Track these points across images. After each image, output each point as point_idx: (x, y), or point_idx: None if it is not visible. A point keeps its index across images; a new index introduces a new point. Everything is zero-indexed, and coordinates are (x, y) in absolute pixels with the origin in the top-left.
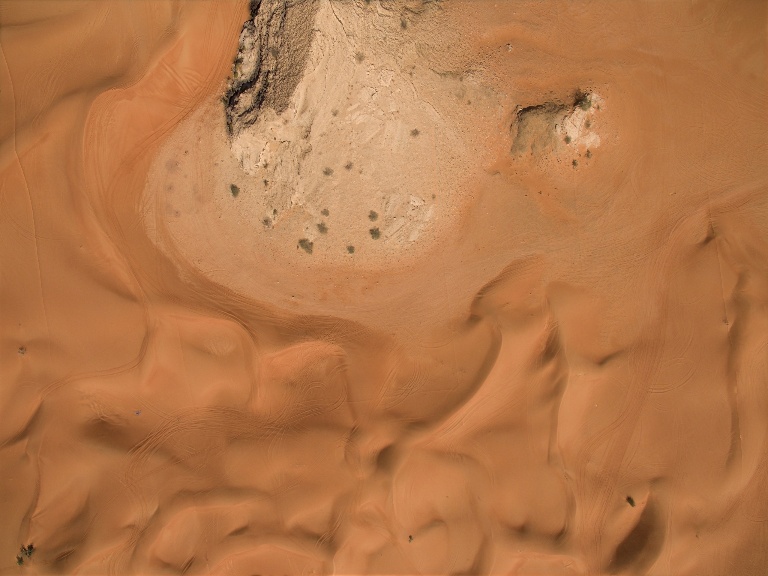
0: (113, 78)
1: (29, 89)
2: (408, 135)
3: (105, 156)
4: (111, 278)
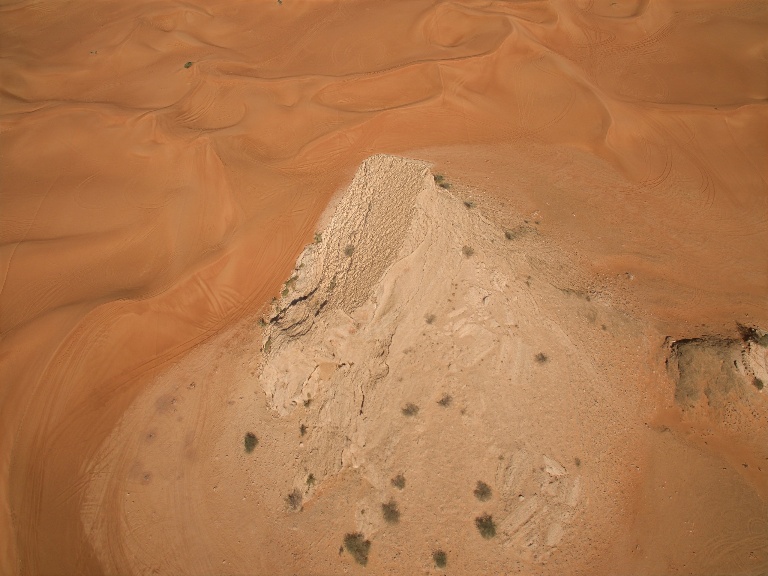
0: (128, 290)
1: (17, 302)
2: (531, 360)
3: (72, 382)
4: None
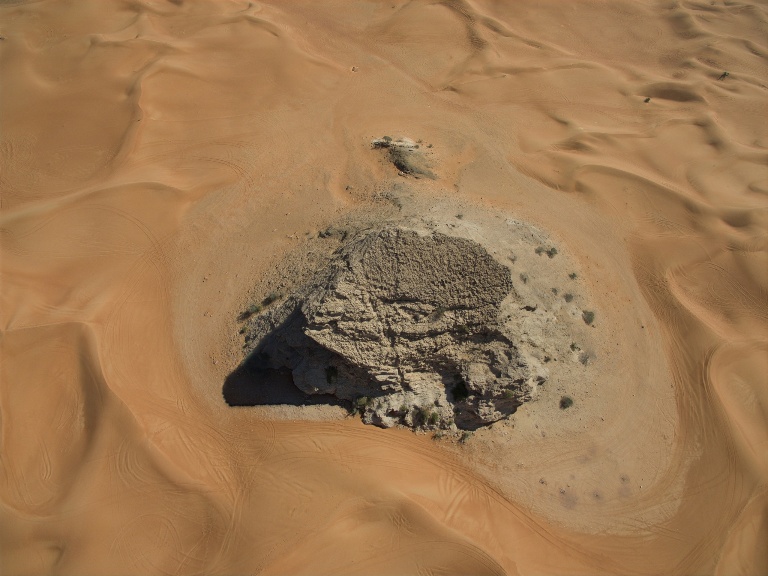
0: None
1: None
2: None
3: None
4: (763, 563)
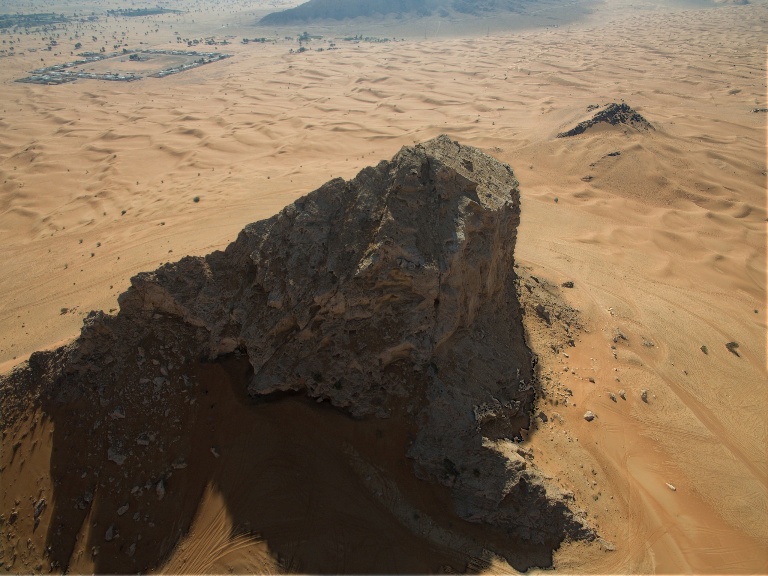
0: None
1: None
2: None
3: None
4: None
